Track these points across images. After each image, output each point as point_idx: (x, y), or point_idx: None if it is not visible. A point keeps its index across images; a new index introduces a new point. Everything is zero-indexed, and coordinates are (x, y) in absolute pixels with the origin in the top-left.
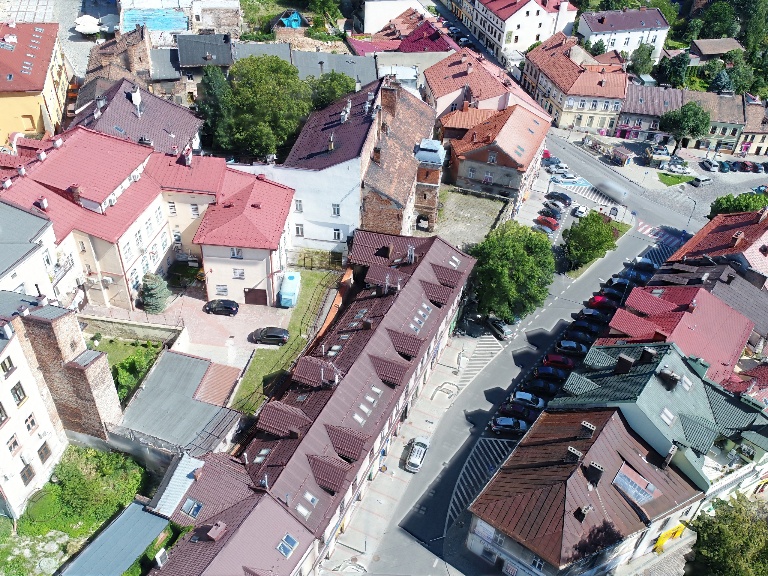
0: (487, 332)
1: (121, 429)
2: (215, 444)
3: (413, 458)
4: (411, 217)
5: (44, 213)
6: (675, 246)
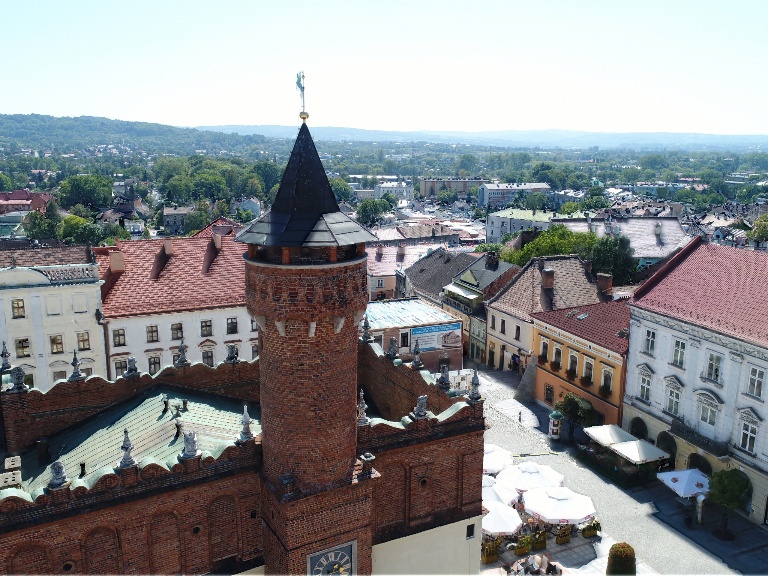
0: None
1: None
2: None
3: None
4: None
5: None
6: None
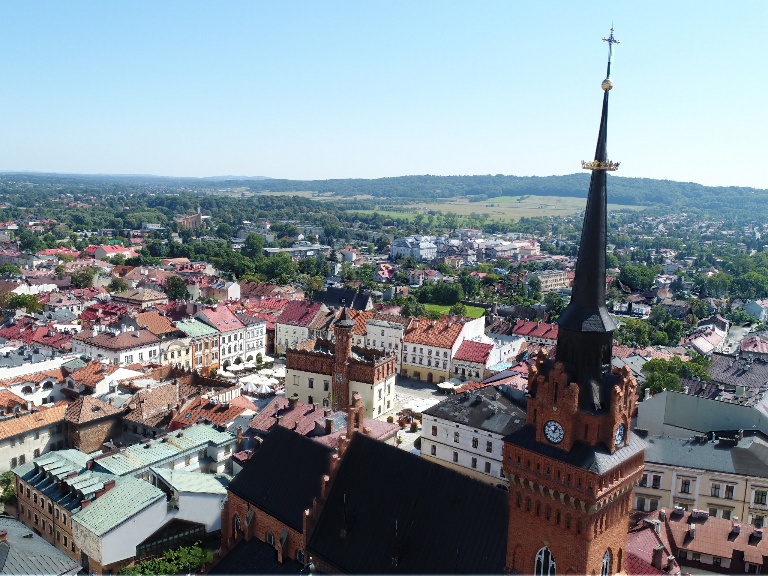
0: None
1: None
2: None
3: None
4: None
5: None
6: None
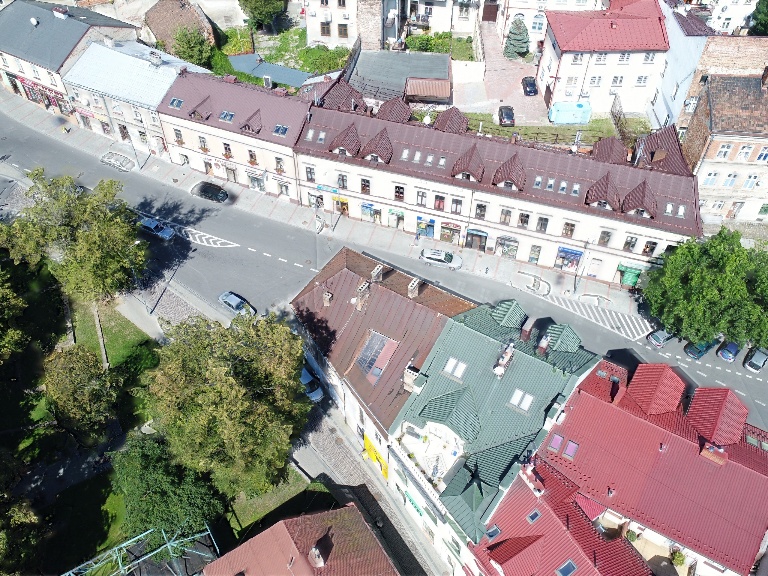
0: (656, 325)
1: (357, 42)
2: (369, 95)
3: (429, 250)
4: (761, 183)
5: None
6: None
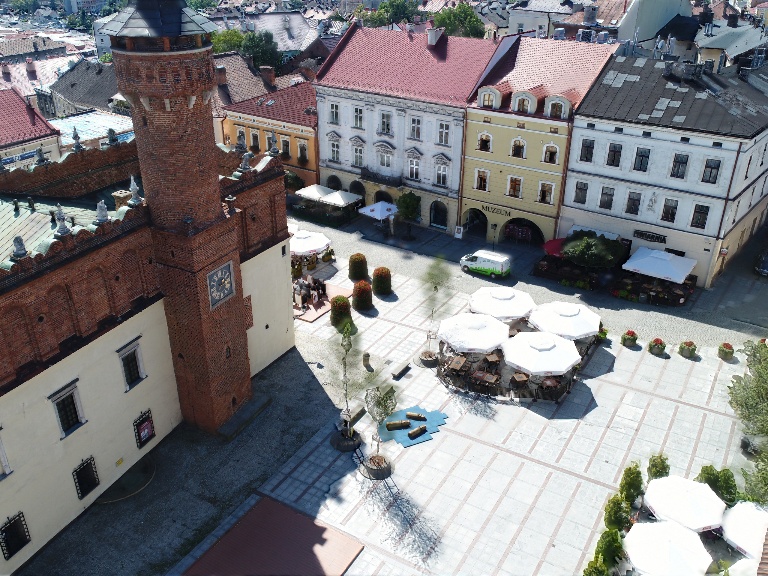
0: None
1: None
2: None
3: None
4: None
5: None
6: None
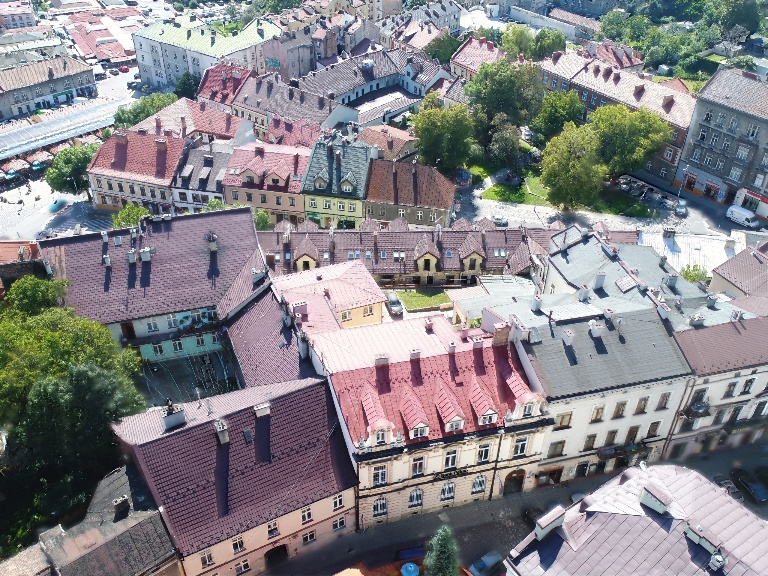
0: None
1: None
2: (508, 276)
3: None
4: None
5: (469, 337)
6: (80, 222)
